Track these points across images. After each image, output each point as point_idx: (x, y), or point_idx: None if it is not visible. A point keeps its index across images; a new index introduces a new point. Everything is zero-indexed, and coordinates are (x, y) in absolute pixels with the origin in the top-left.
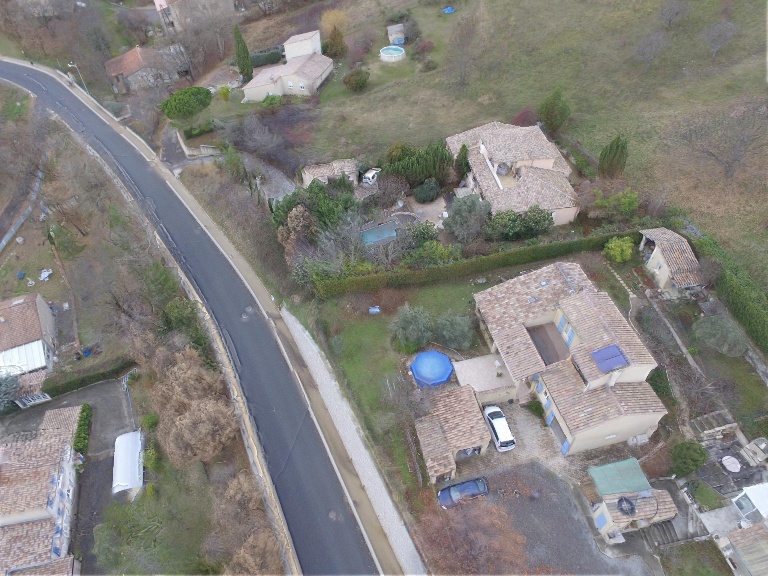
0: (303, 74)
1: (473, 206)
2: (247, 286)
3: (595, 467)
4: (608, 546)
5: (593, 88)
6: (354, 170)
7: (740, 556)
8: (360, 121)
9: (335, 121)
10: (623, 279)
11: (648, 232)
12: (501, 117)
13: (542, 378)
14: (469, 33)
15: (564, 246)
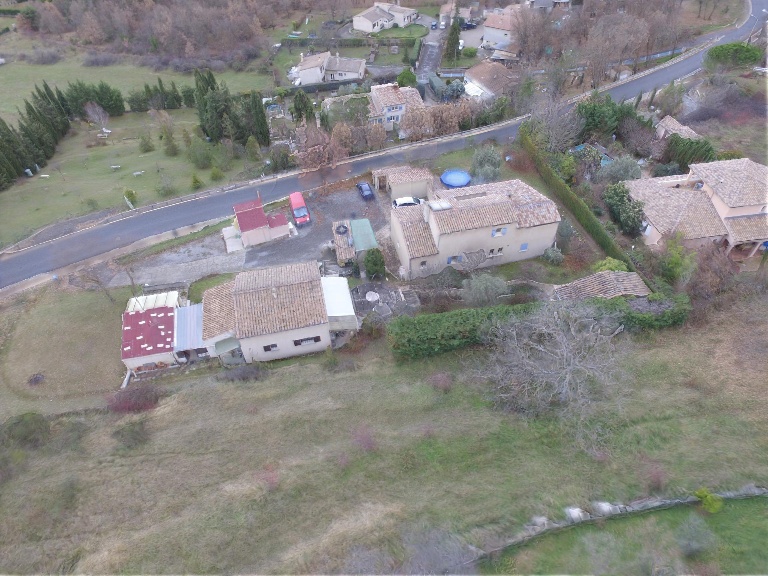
0: None
1: None
2: None
3: None
4: None
5: None
6: None
7: None
8: None
9: None
10: None
11: (634, 276)
12: None
13: None
14: None
15: (601, 233)
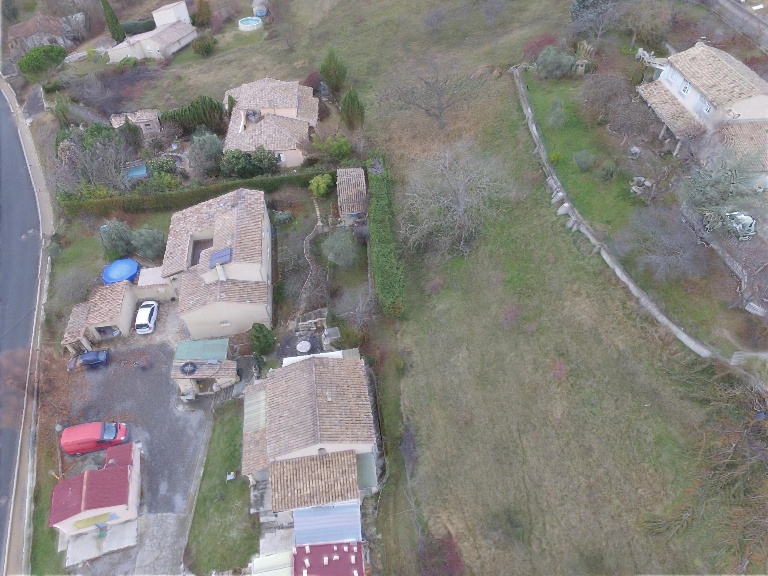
0: (159, 39)
1: (205, 144)
2: (39, 214)
3: (185, 341)
4: (183, 403)
5: (388, 55)
6: (151, 118)
7: (244, 402)
8: (192, 81)
9: (172, 80)
10: (320, 211)
11: (342, 170)
12: (303, 79)
13: (182, 276)
14: (285, 2)
15: (276, 181)
